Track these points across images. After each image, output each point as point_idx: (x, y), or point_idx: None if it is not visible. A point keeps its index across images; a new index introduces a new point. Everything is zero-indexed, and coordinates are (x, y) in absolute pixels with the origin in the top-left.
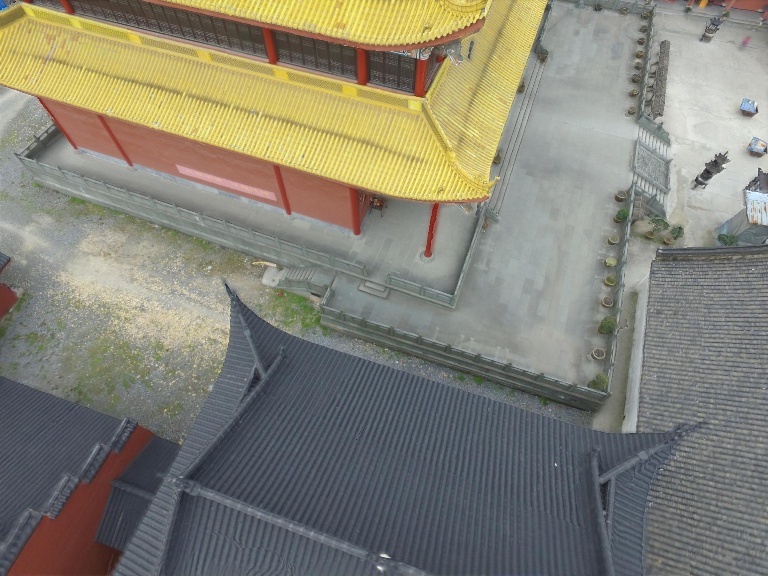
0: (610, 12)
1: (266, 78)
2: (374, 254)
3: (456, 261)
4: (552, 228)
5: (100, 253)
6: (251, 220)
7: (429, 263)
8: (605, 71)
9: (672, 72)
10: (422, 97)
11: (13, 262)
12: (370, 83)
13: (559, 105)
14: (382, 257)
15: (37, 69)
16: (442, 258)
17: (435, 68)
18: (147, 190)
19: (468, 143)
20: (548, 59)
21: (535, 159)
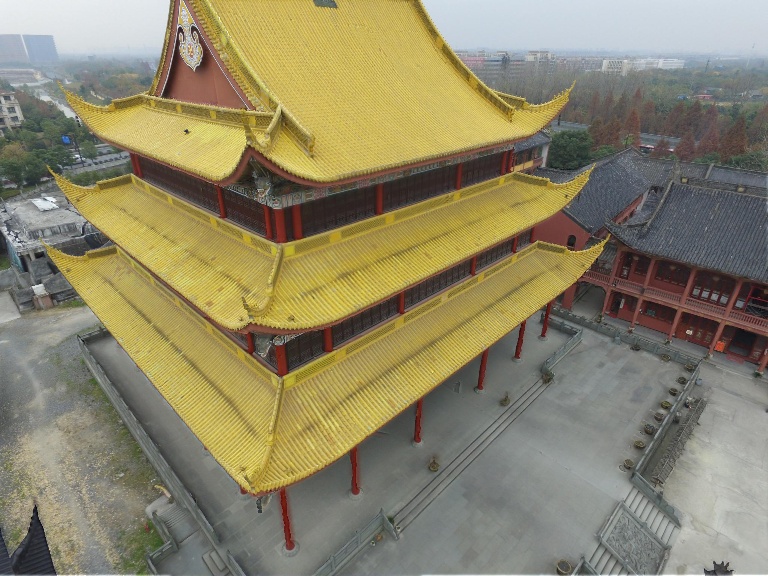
0: (649, 355)
1: (203, 328)
2: (244, 522)
3: (316, 568)
4: (455, 575)
5: (65, 429)
6: (175, 443)
7: (286, 557)
8: (616, 411)
9: (714, 436)
10: (280, 376)
11: (10, 413)
12: (255, 353)
13: (543, 431)
14: (248, 529)
15: (97, 285)
16: (304, 558)
17: (319, 356)
18: (131, 389)
19: (317, 433)
20: (555, 382)
21: (483, 481)
